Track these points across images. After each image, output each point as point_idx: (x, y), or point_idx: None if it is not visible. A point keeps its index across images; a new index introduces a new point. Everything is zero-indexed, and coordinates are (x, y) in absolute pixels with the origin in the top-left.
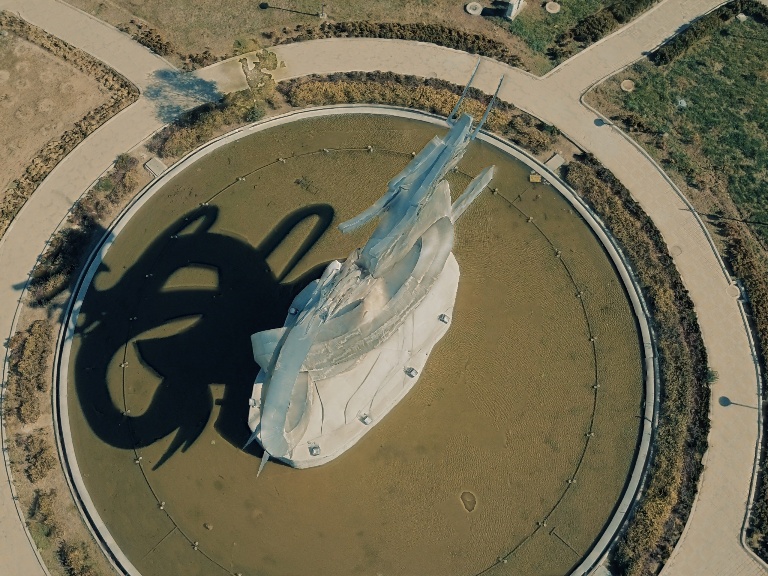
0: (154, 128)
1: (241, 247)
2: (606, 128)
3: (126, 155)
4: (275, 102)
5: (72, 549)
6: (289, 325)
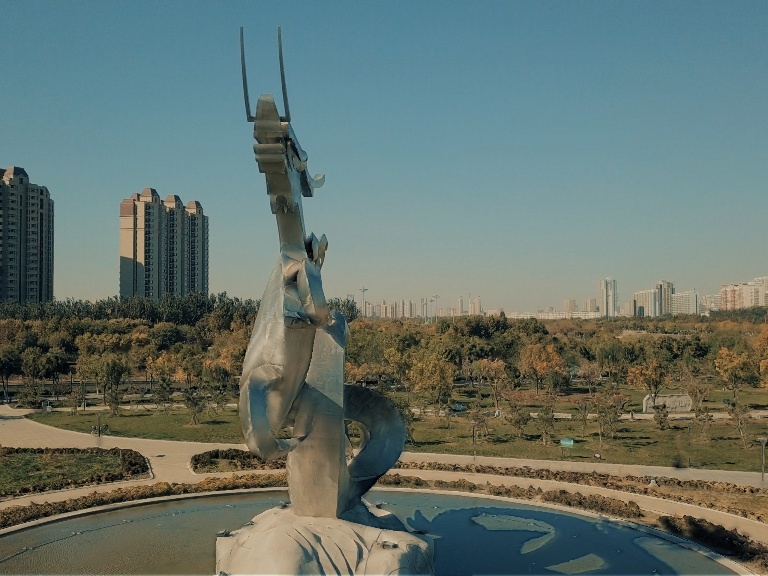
0: None
1: None
2: None
3: None
4: None
5: (419, 482)
6: None
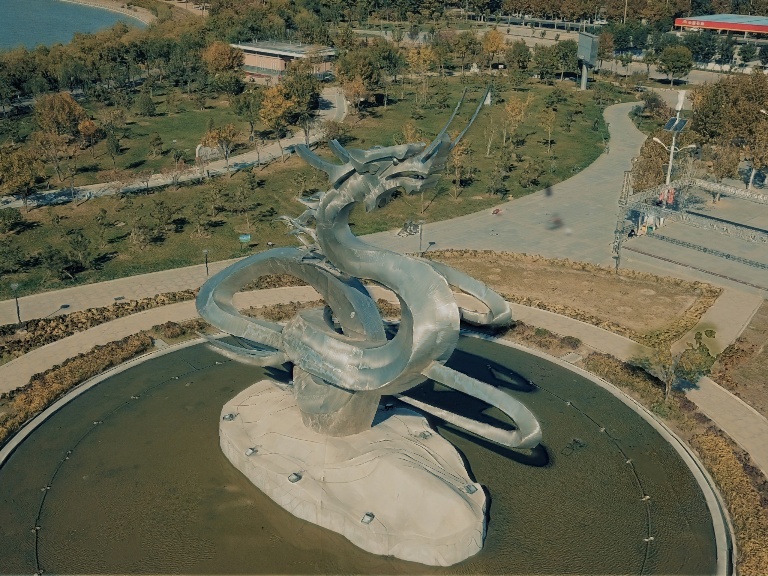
0: (619, 356)
1: (482, 404)
2: None
3: (578, 339)
4: (687, 424)
5: (202, 326)
6: None
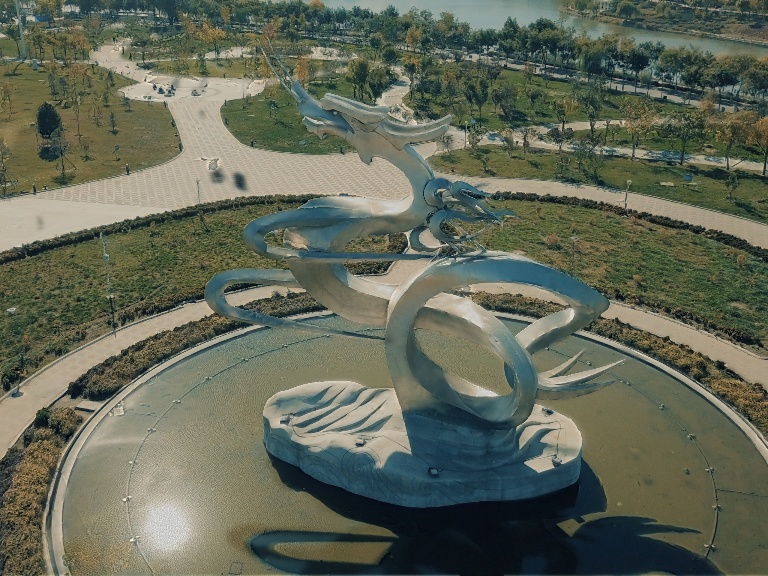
0: None
1: None
2: (25, 390)
3: None
4: None
5: None
6: (510, 272)
